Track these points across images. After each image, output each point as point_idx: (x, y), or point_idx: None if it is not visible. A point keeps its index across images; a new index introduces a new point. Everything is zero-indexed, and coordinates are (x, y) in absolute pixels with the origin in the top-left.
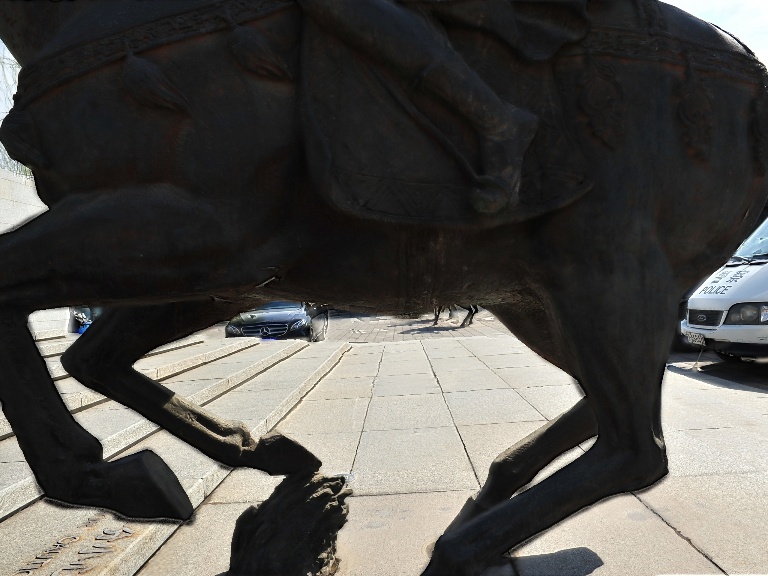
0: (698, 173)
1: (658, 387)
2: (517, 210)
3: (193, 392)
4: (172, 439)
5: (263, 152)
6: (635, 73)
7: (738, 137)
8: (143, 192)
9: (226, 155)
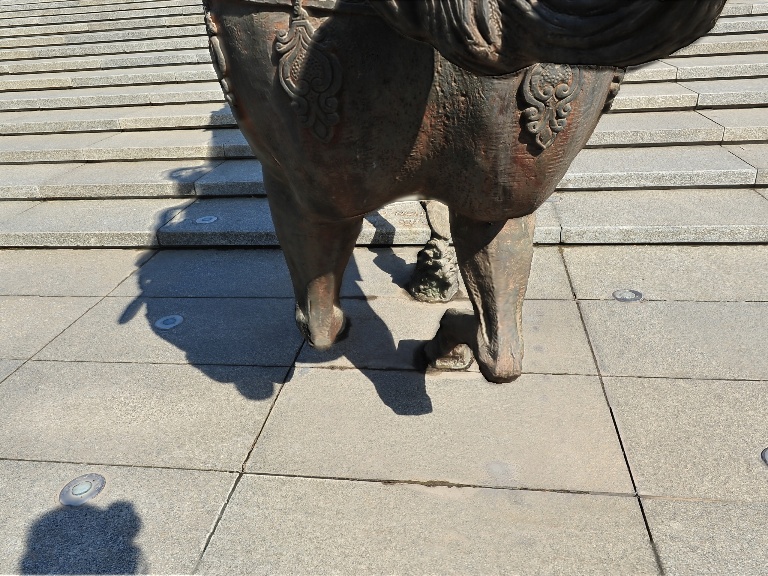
0: None
1: (302, 281)
2: None
3: None
4: (686, 198)
5: None
6: None
7: None
8: None
9: None
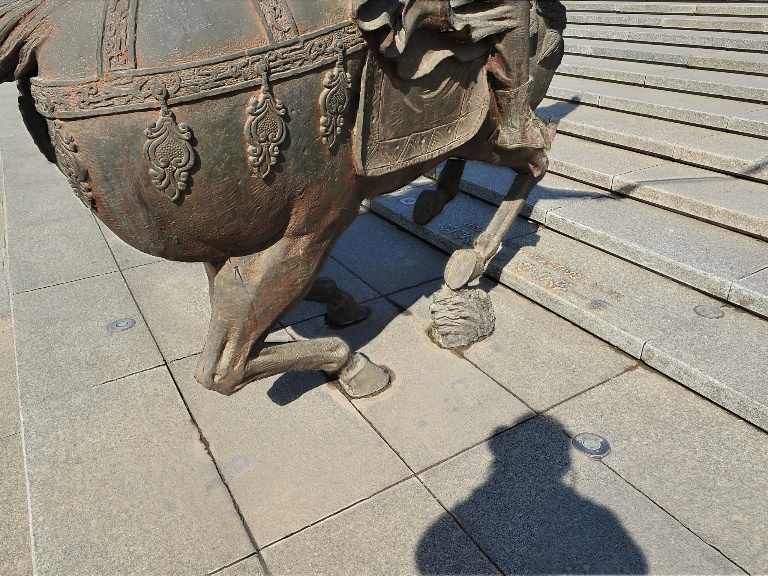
0: None
1: None
2: None
3: None
4: None
5: None
6: None
7: None
8: None
9: None
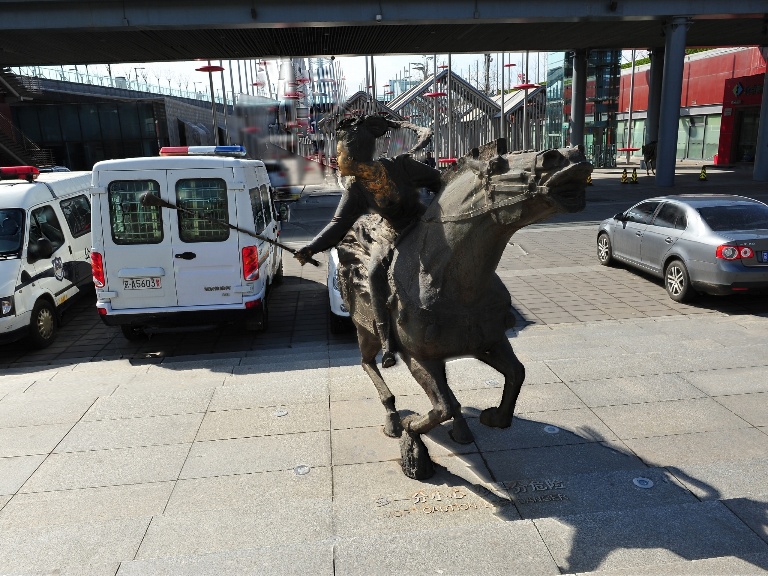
0: None
1: None
2: None
3: (28, 575)
4: None
5: None
6: None
7: None
8: None
9: None
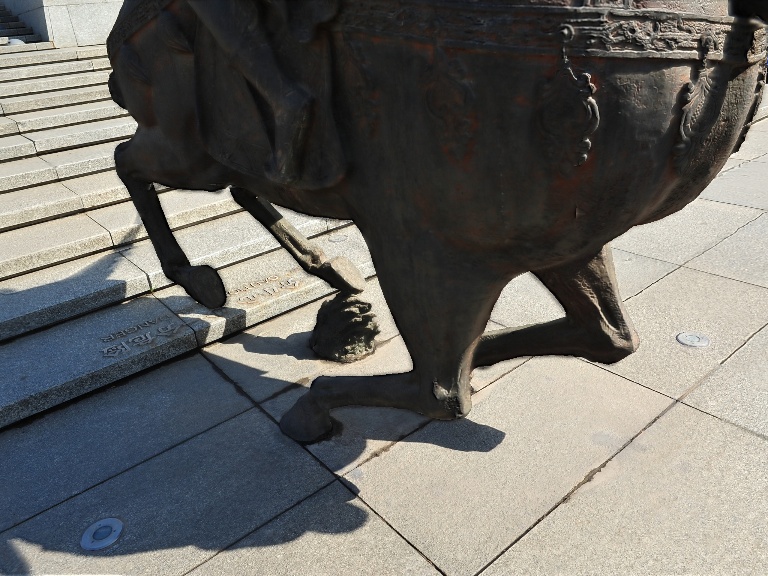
0: (455, 172)
1: (453, 352)
2: (309, 180)
3: None
4: None
5: (185, 111)
6: (383, 54)
7: (509, 133)
8: (147, 132)
9: (168, 113)
